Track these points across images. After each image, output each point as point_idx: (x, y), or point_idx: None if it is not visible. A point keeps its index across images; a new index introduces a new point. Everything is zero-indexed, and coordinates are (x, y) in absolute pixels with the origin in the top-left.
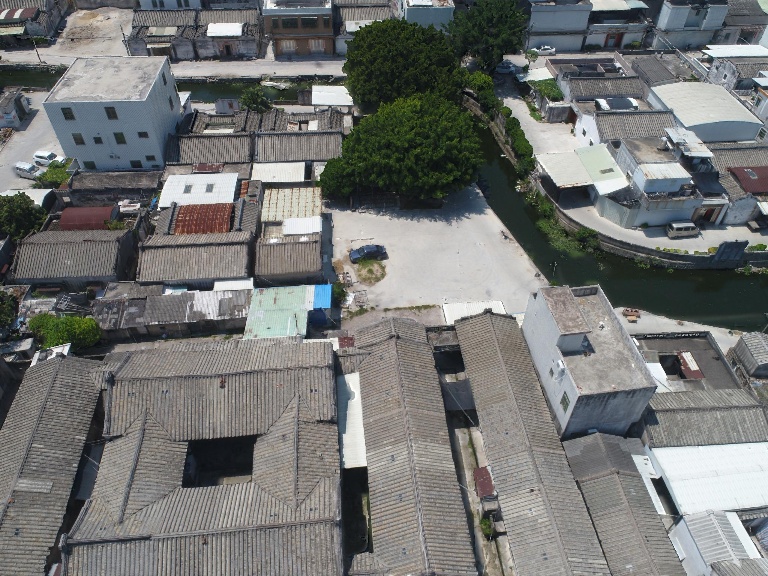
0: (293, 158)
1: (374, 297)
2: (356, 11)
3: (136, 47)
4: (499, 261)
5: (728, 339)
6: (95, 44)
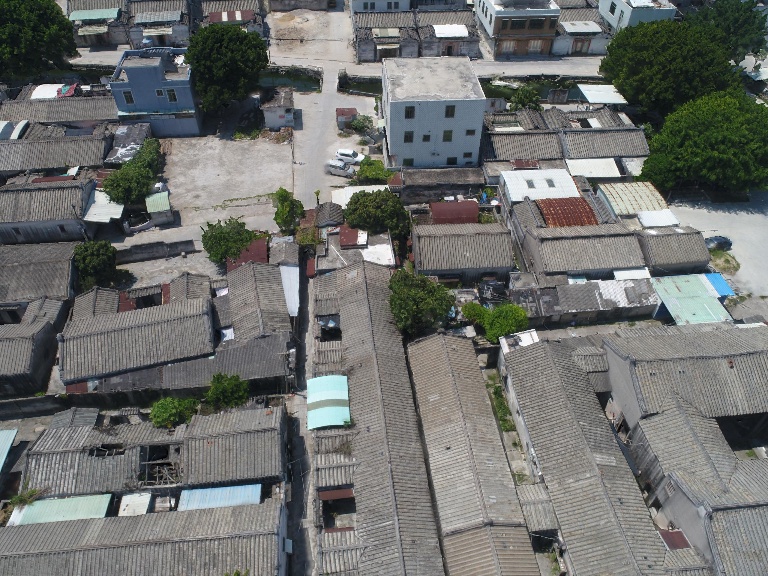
0: (603, 154)
1: (743, 285)
2: (566, 12)
3: (365, 48)
4: None
5: None
6: (310, 45)
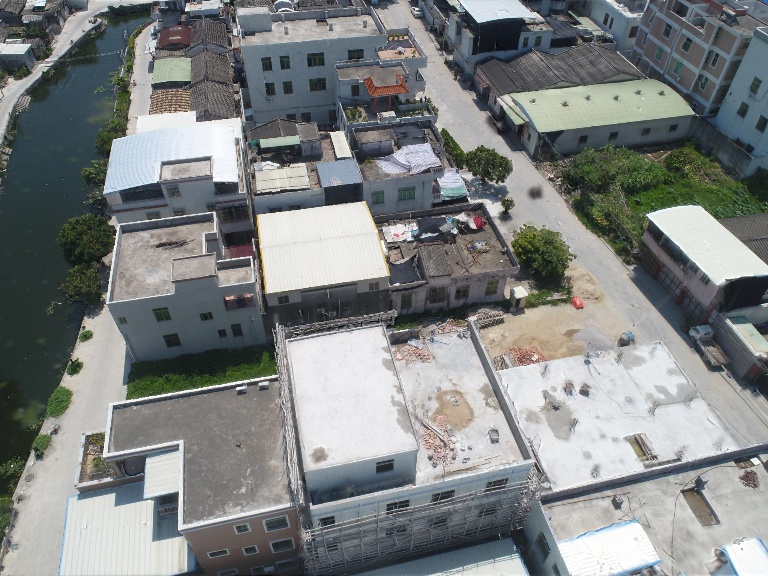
0: None
1: None
2: None
3: None
4: None
5: (69, 41)
6: None
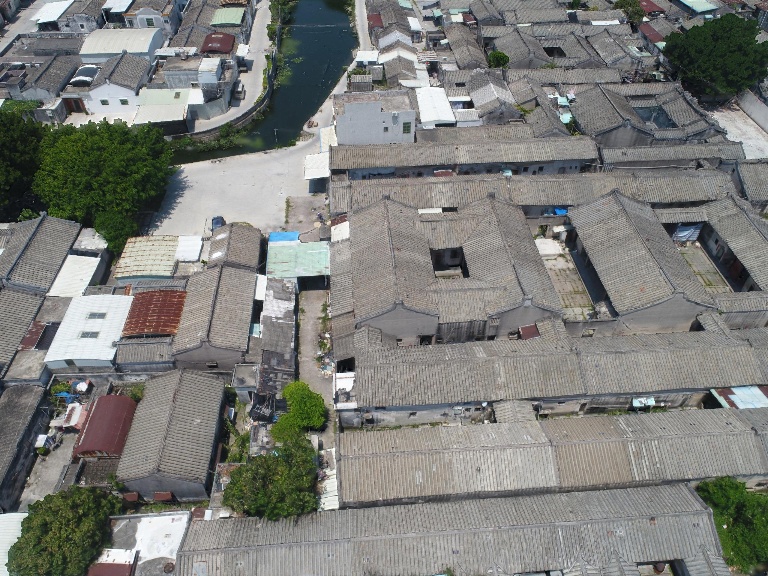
0: (60, 260)
1: (270, 228)
2: None
3: None
4: (246, 167)
5: None
6: None
